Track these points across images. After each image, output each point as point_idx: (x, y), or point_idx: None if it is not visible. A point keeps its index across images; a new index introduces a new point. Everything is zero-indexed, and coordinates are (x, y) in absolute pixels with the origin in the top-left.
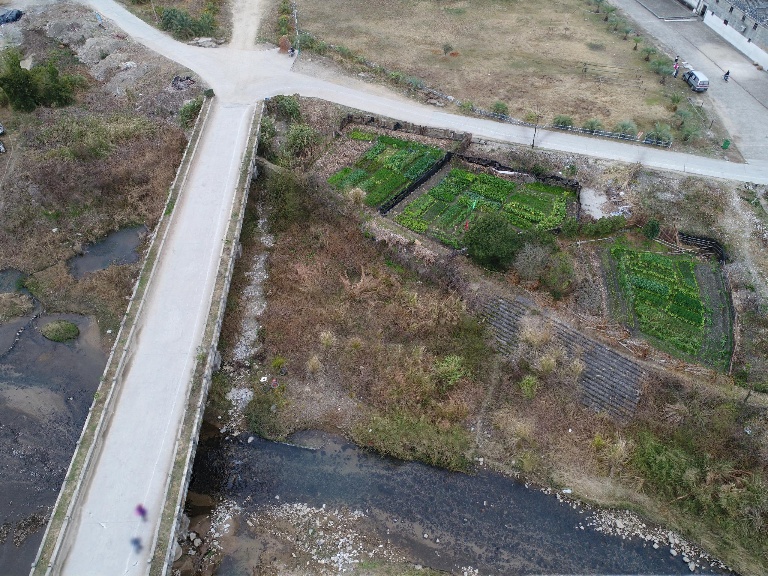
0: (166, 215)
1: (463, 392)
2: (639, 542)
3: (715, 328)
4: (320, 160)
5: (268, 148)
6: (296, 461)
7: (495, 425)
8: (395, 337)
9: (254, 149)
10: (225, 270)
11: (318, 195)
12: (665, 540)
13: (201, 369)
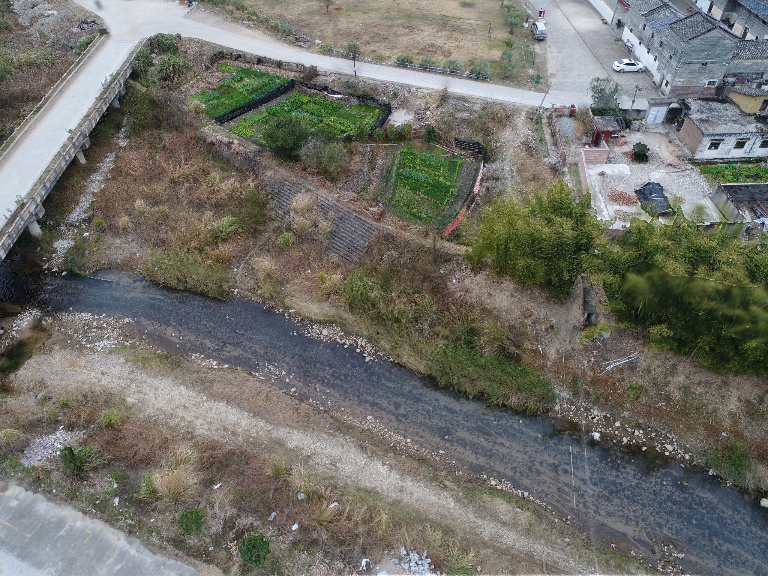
0: (32, 115)
1: (234, 243)
2: (335, 344)
3: (454, 206)
4: (185, 85)
5: (141, 74)
6: (95, 289)
7: (252, 266)
8: (198, 208)
9: (123, 72)
10: (63, 151)
11: (170, 109)
12: (355, 343)
13: (19, 211)
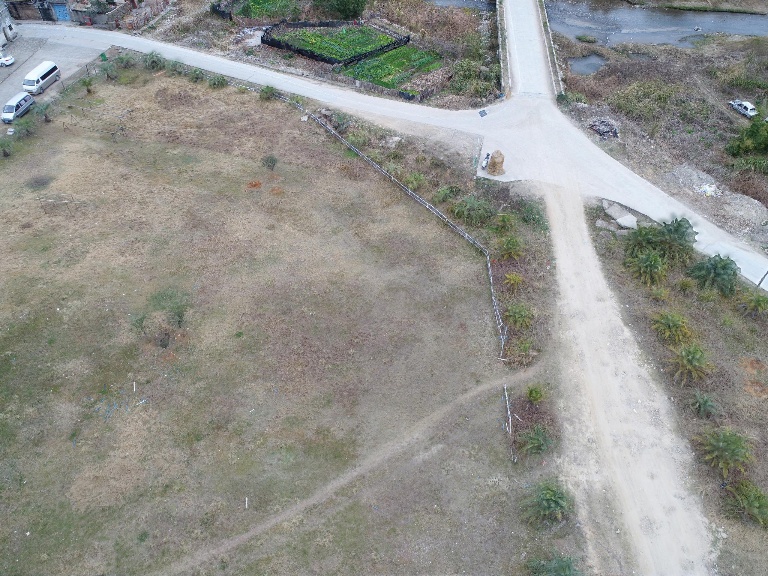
0: None
1: None
2: None
3: None
4: None
5: None
6: (458, 7)
7: None
8: None
9: None
10: None
11: None
12: None
13: None
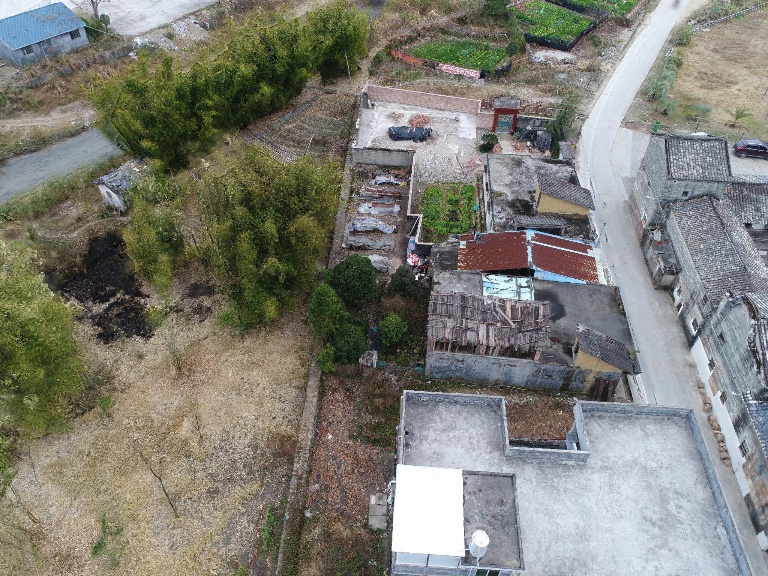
0: None
1: (411, 8)
2: None
3: None
4: None
5: None
6: None
7: None
8: None
9: None
10: None
11: None
12: None
13: None
